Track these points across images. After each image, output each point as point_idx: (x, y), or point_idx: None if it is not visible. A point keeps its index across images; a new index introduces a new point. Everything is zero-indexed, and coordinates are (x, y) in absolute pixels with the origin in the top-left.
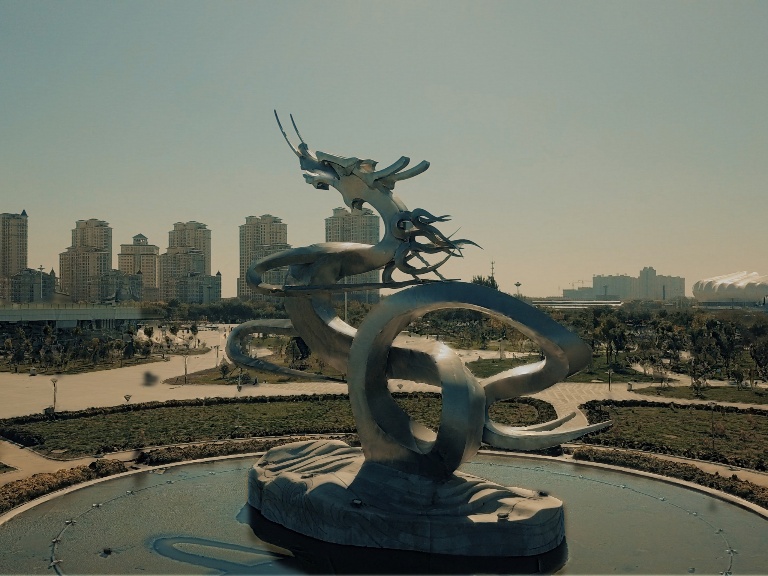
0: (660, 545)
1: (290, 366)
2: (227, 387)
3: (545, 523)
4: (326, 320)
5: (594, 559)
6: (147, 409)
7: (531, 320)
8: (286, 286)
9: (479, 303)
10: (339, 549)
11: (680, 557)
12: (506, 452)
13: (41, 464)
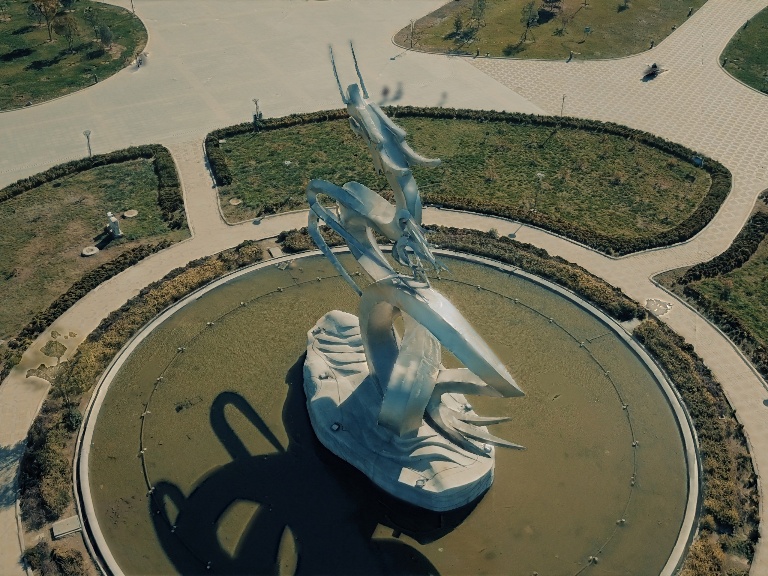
0: (553, 524)
1: (541, 7)
2: (444, 63)
3: (453, 495)
4: (358, 254)
5: (481, 529)
6: (341, 118)
7: (471, 361)
8: (329, 218)
9: (434, 332)
10: (322, 448)
11: (547, 551)
12: (582, 301)
13: (212, 227)
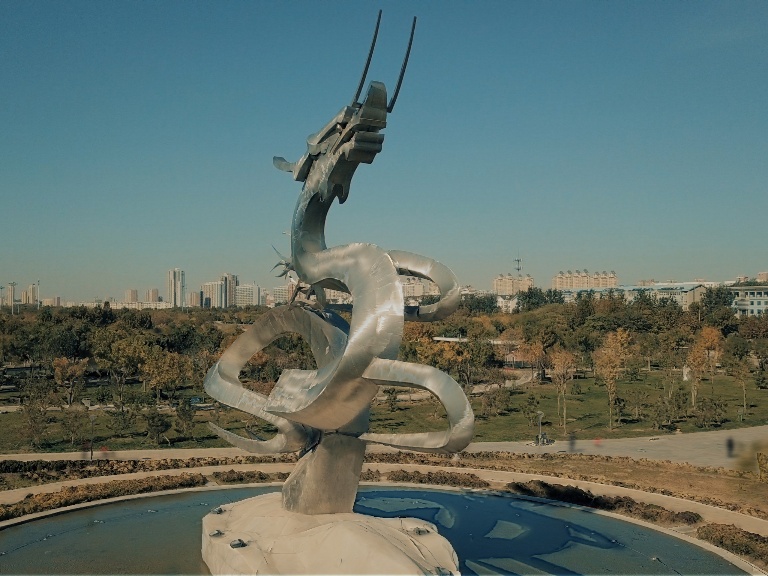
0: (171, 525)
1: None
2: None
3: None
4: None
5: None
6: None
7: None
8: None
9: None
10: None
11: (192, 516)
12: None
13: None
